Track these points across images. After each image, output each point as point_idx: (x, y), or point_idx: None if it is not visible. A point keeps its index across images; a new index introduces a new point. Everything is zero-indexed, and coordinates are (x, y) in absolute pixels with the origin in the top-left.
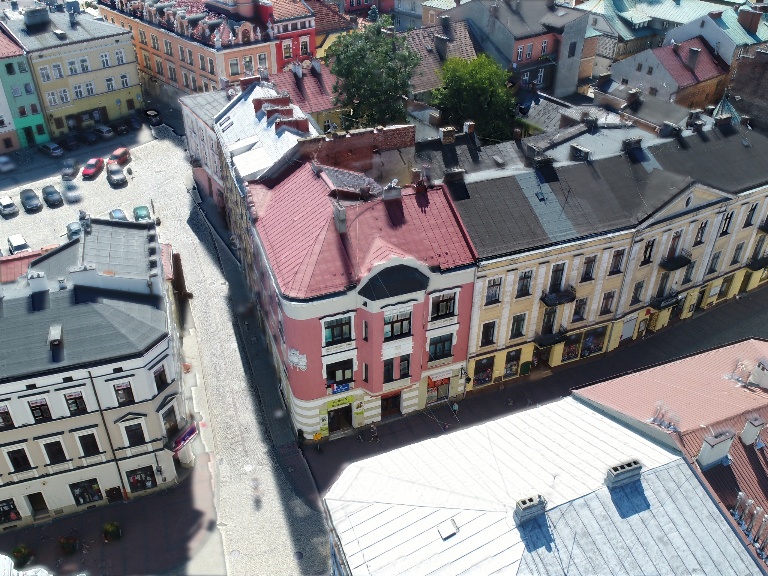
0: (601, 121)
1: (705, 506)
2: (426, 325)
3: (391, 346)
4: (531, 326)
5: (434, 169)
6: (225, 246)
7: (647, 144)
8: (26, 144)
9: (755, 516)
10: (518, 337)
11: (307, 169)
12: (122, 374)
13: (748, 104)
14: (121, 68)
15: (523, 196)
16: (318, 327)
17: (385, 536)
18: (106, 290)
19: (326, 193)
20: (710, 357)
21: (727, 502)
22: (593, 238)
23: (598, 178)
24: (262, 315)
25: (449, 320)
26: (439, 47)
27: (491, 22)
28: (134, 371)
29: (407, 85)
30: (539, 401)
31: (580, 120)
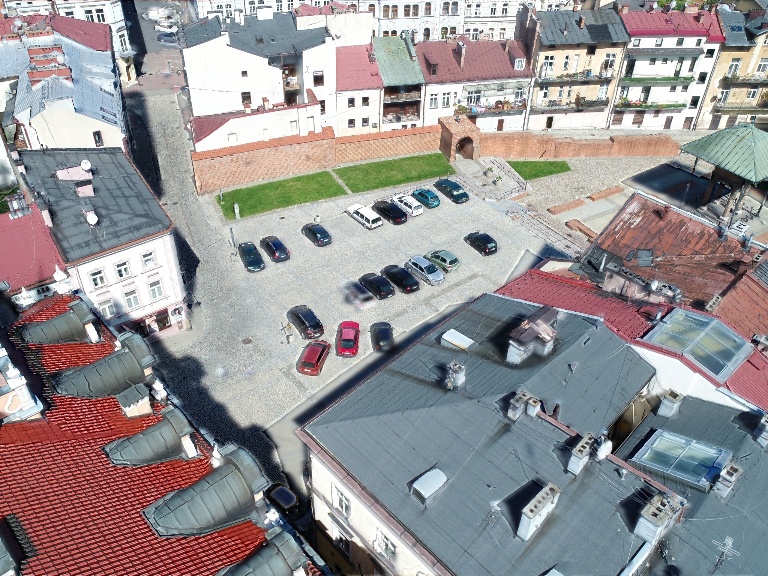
0: None
1: None
2: None
3: None
4: None
5: None
6: None
7: None
8: None
9: None
10: None
11: None
12: None
13: None
14: None
15: None
16: None
17: None
18: None
19: (55, 21)
20: None
21: None
22: None
23: None
24: None
25: None
26: None
27: None
28: None
29: None
30: None
31: None
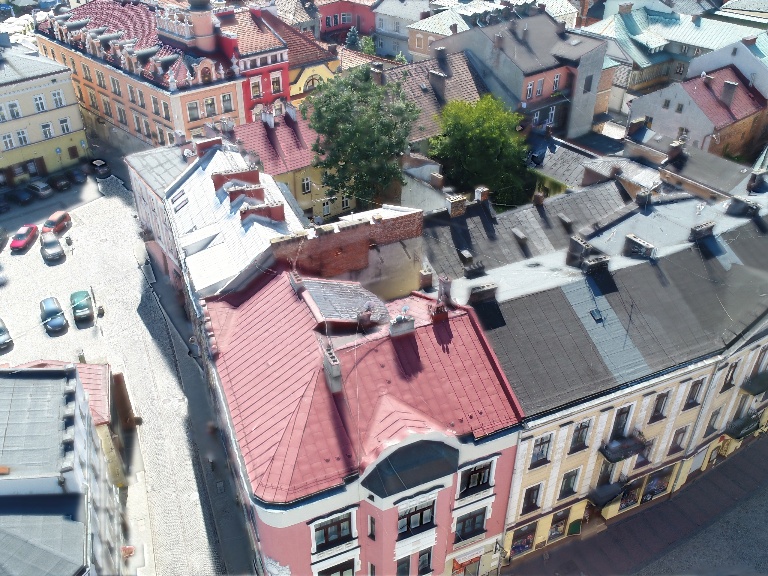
0: (636, 178)
1: None
2: (452, 504)
3: (407, 542)
4: (585, 481)
5: (442, 250)
6: (184, 344)
7: (717, 228)
8: None
9: None
10: (568, 496)
11: (284, 282)
12: None
13: None
14: (60, 112)
15: (574, 317)
16: (305, 532)
17: None
18: None
19: (311, 326)
20: None
21: None
22: (670, 373)
23: (666, 283)
24: (229, 461)
25: (482, 492)
26: (435, 85)
27: (495, 54)
28: None
29: None
30: (596, 575)
31: (609, 176)
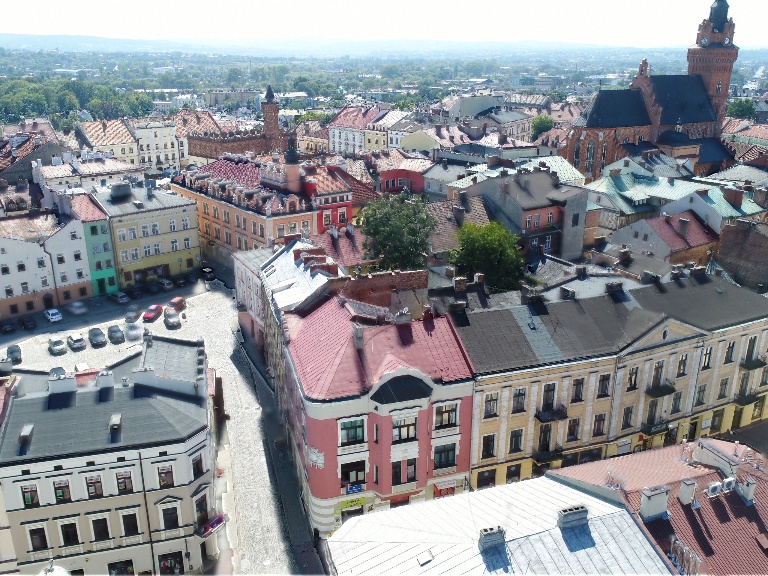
0: None
1: (644, 547)
2: (431, 433)
3: (399, 449)
4: (528, 442)
5: None
6: (262, 378)
7: (629, 288)
8: (98, 293)
9: (685, 554)
10: (517, 452)
11: (334, 301)
12: (166, 458)
13: (736, 266)
14: (185, 232)
15: (517, 325)
16: (335, 427)
17: (374, 565)
18: (160, 389)
19: (348, 318)
20: (669, 449)
21: (665, 548)
22: (578, 361)
23: (583, 313)
24: (289, 431)
25: (452, 430)
26: (457, 216)
27: (503, 196)
28: (176, 456)
29: (426, 244)
30: None
31: None
